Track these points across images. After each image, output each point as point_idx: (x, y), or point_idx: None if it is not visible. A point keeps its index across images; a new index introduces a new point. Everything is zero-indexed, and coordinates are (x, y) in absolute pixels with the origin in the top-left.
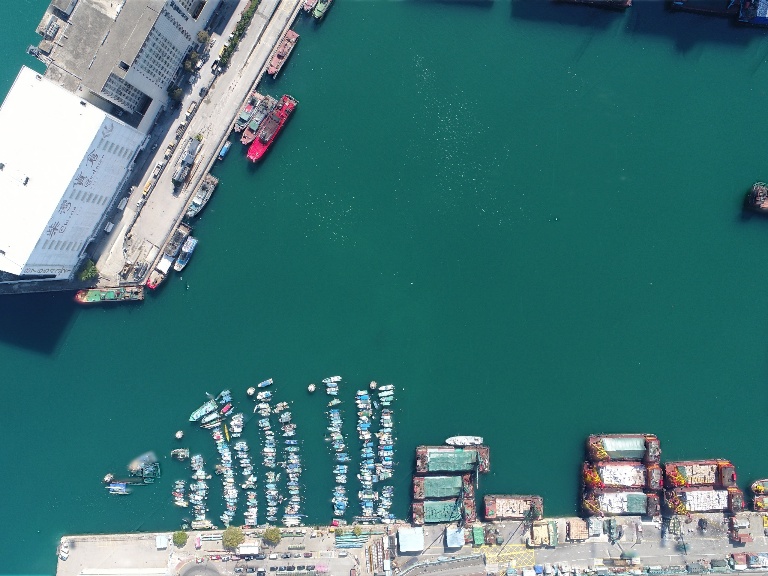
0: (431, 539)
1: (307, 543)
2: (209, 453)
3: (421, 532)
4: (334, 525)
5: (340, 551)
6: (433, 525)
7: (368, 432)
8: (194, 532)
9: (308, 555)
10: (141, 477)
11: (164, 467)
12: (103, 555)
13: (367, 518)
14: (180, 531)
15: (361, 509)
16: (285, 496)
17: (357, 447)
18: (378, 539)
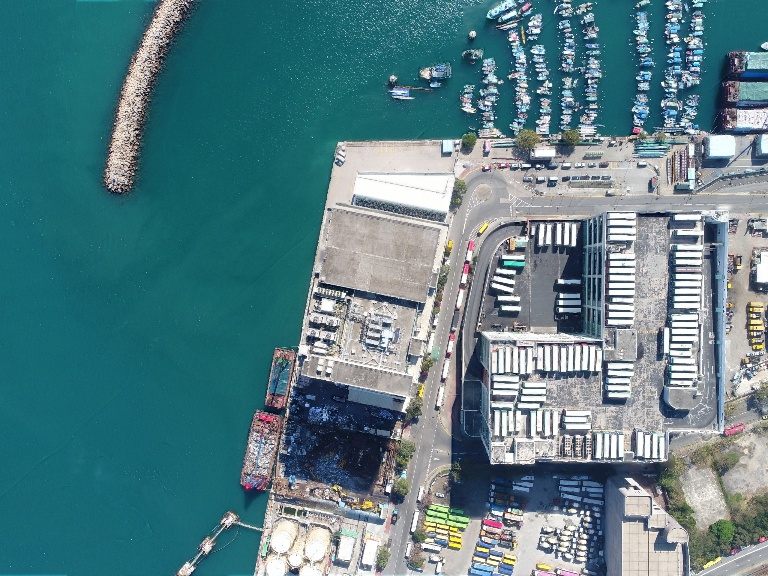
0: (738, 151)
1: (604, 152)
2: (502, 56)
3: (733, 136)
4: (634, 133)
5: (639, 161)
6: (741, 136)
7: (677, 36)
8: (482, 139)
9: (605, 163)
10: (427, 81)
11: (453, 70)
12: (382, 161)
13: (668, 129)
14: (470, 133)
15: (663, 119)
16: (581, 104)
17: (663, 53)
18: (681, 149)
